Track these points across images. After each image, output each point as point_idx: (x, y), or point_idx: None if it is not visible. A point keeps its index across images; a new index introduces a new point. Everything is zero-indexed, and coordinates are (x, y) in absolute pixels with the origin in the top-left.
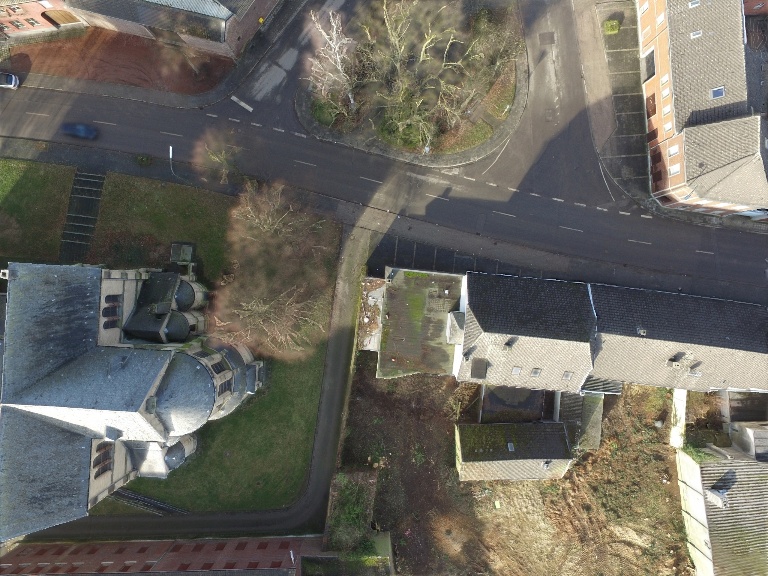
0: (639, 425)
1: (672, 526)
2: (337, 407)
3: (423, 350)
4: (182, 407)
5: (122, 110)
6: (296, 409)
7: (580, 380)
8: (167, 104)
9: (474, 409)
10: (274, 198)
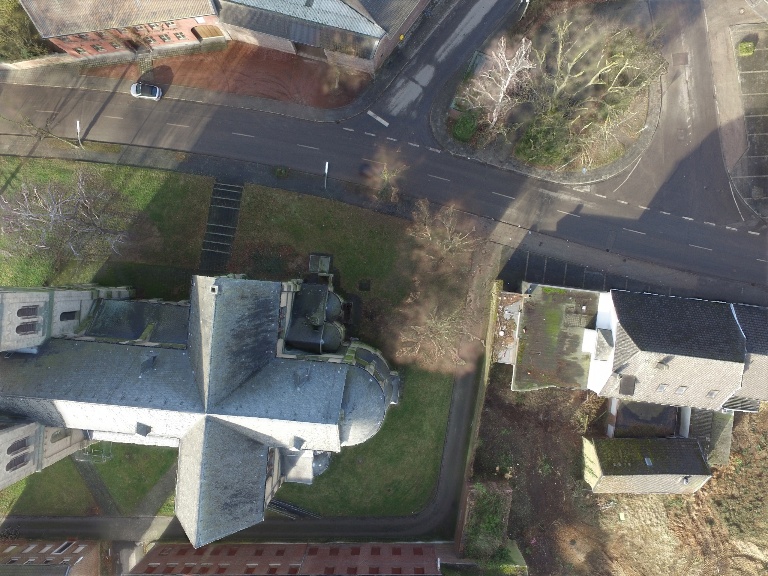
0: (764, 442)
1: None
2: (466, 417)
3: (558, 364)
4: (361, 419)
5: (260, 123)
6: (427, 419)
7: (724, 398)
8: (305, 117)
9: (601, 422)
10: (446, 217)
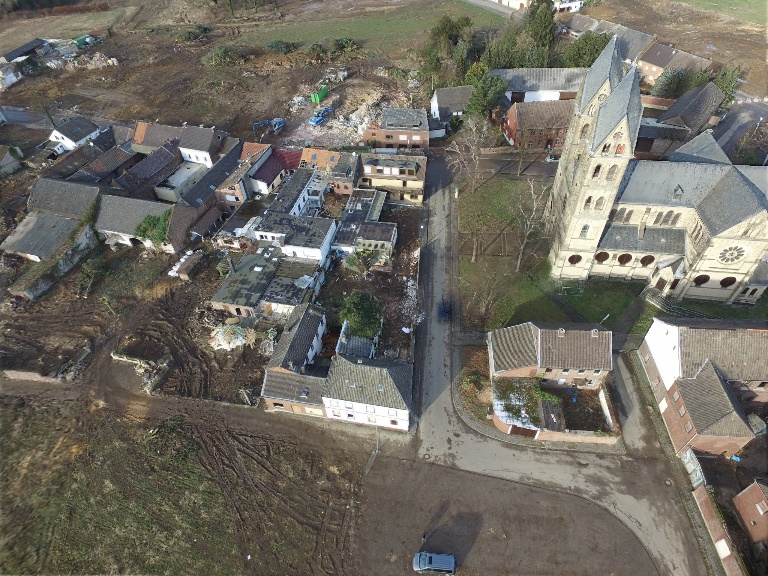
0: None
1: None
2: None
3: None
4: None
5: None
6: None
7: None
8: None
9: None
10: None
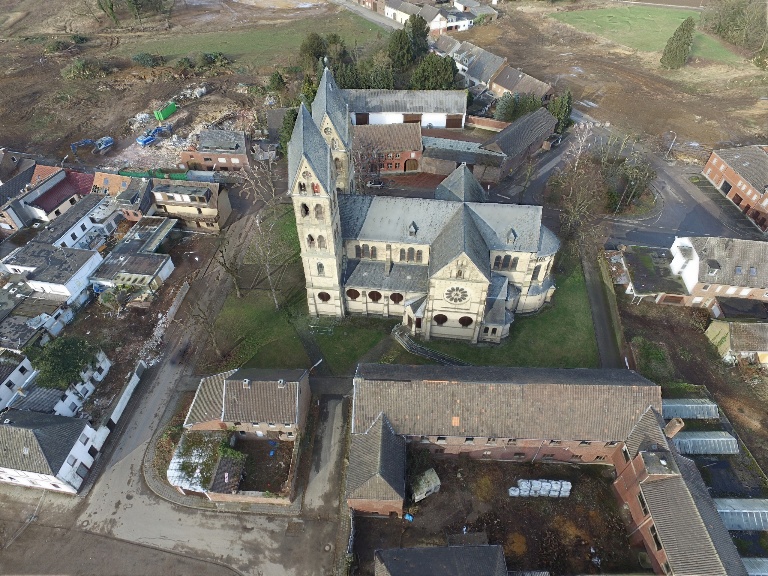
0: None
1: None
2: (607, 321)
3: (661, 281)
4: (548, 233)
5: None
6: (577, 319)
7: None
8: None
9: None
10: None
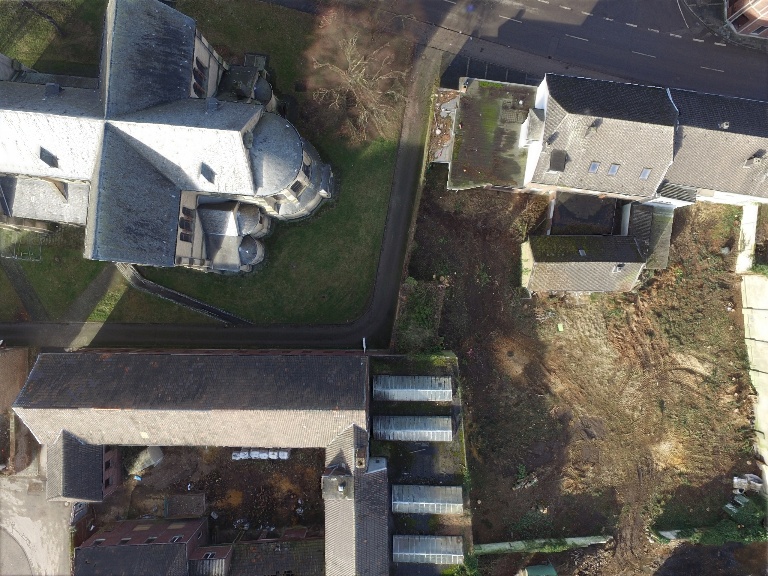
0: (705, 252)
1: (735, 354)
2: (404, 225)
3: (495, 161)
4: (274, 156)
5: None
6: (363, 224)
7: (657, 180)
8: None
9: (540, 231)
10: None
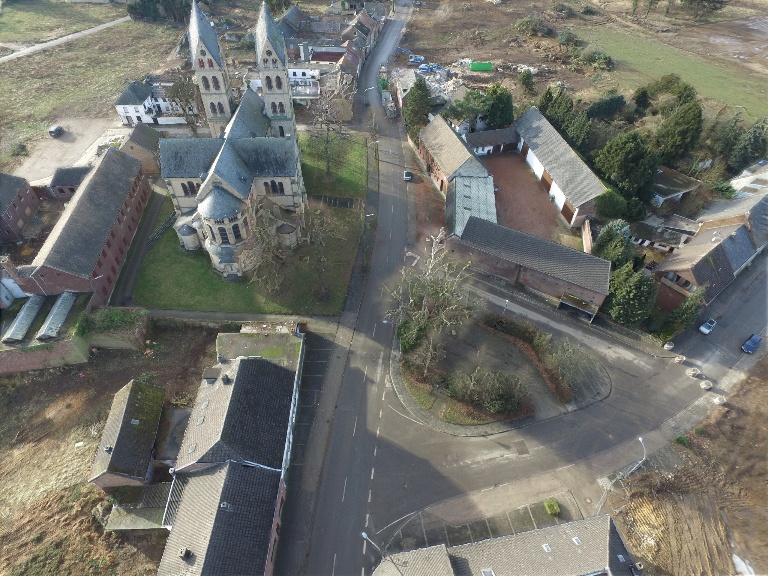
0: None
1: None
2: None
3: None
4: (214, 201)
5: (401, 214)
6: (204, 298)
7: (186, 463)
8: (409, 231)
9: None
10: None
